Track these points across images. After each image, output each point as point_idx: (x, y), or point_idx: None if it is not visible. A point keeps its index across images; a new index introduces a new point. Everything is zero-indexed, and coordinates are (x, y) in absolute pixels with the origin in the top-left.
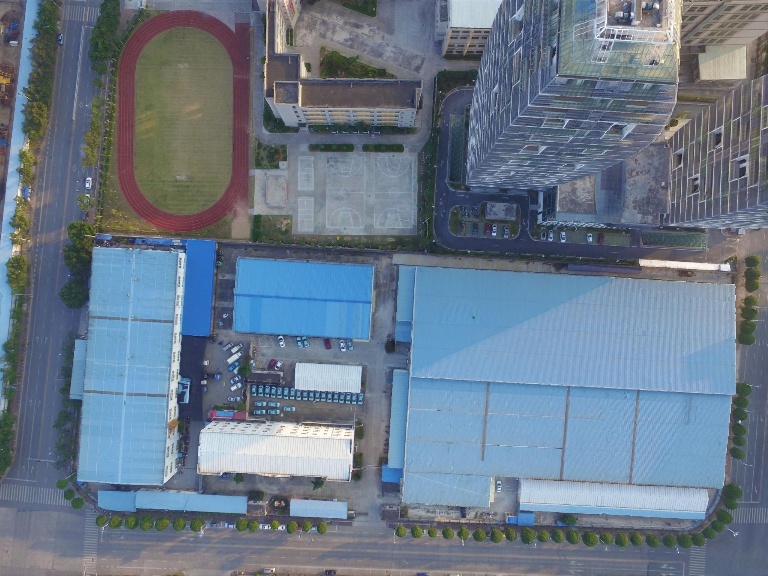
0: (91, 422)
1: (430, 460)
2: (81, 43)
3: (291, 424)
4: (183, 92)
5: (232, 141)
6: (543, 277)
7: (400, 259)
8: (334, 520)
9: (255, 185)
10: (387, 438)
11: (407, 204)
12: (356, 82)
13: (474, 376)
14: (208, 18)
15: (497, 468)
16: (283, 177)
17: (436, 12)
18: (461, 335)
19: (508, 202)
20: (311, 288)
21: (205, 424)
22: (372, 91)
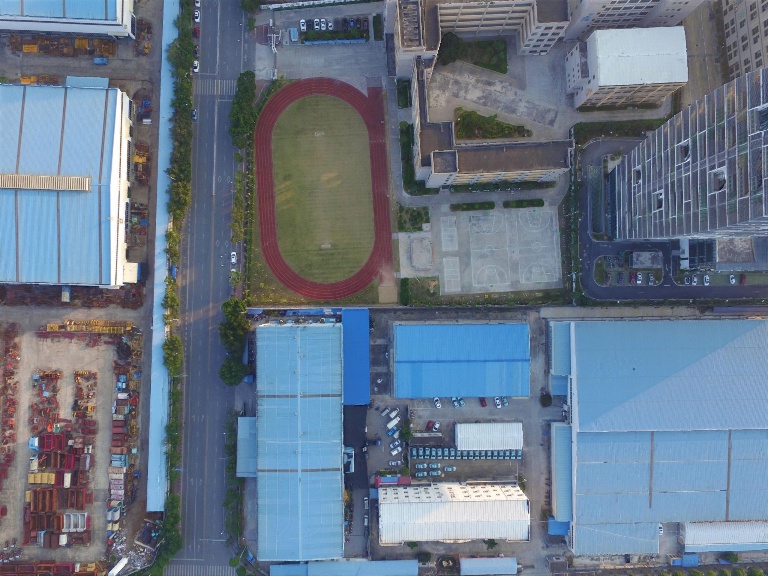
0: (267, 501)
1: (599, 511)
2: (215, 117)
3: (455, 484)
4: (321, 160)
5: (373, 206)
6: (697, 324)
7: (548, 312)
8: (501, 575)
9: (399, 249)
10: (548, 490)
11: (551, 257)
12: (509, 146)
13: (640, 427)
14: (340, 84)
15: (664, 514)
16: (427, 239)
17: (569, 66)
18: (623, 387)
19: (651, 249)
20: (469, 350)
21: (370, 491)
22: (525, 153)
